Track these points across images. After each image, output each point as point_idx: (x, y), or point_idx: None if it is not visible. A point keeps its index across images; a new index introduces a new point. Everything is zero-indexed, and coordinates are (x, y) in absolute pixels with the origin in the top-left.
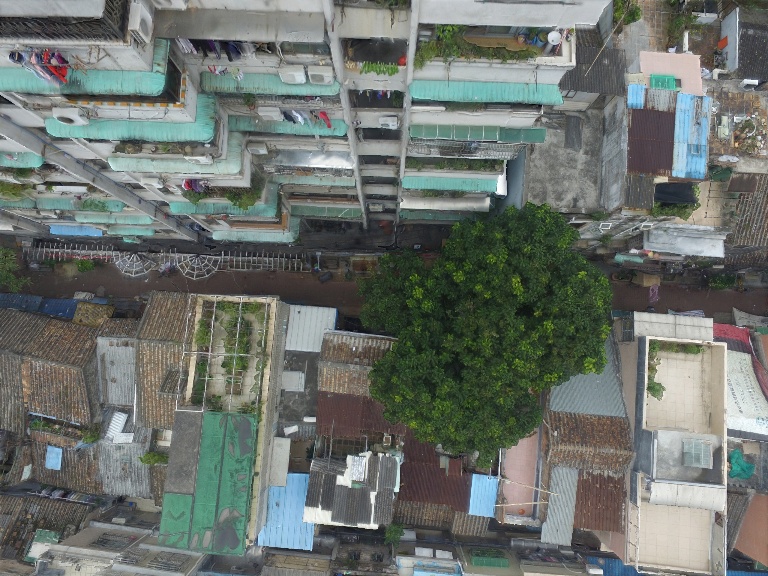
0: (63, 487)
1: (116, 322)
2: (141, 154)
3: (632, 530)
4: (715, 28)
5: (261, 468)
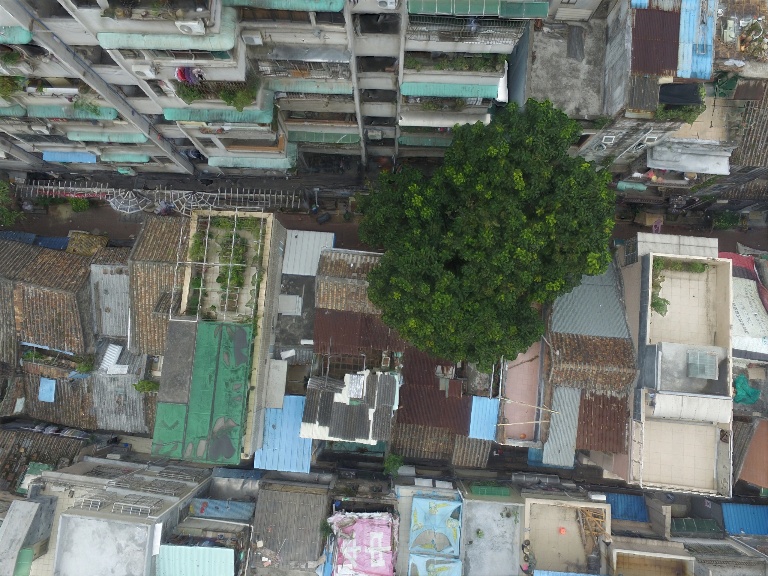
0: (57, 422)
1: (110, 251)
2: (131, 28)
3: (636, 449)
4: None
5: (257, 384)
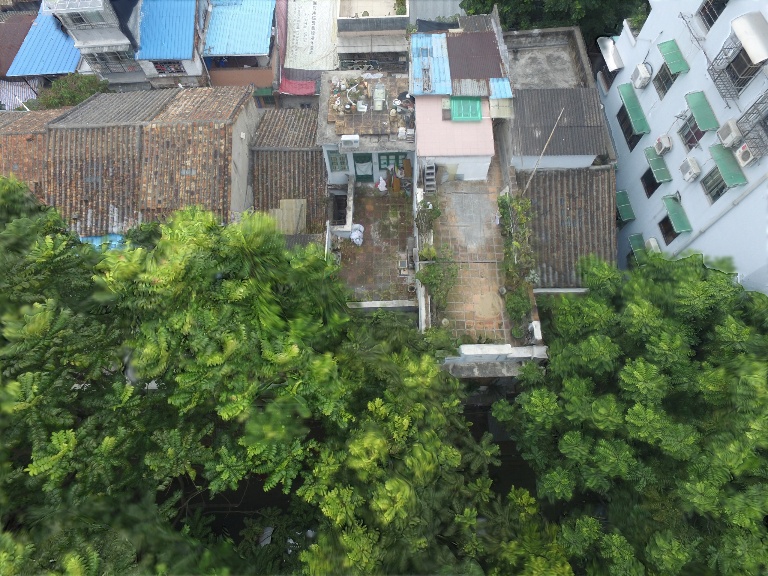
0: None
1: None
2: None
3: None
4: None
5: None
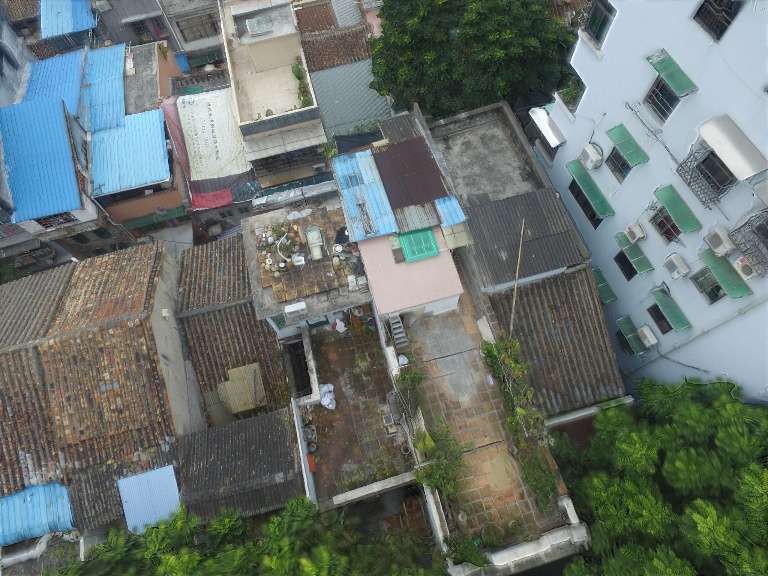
0: None
1: None
2: None
3: None
4: (325, 496)
5: None
